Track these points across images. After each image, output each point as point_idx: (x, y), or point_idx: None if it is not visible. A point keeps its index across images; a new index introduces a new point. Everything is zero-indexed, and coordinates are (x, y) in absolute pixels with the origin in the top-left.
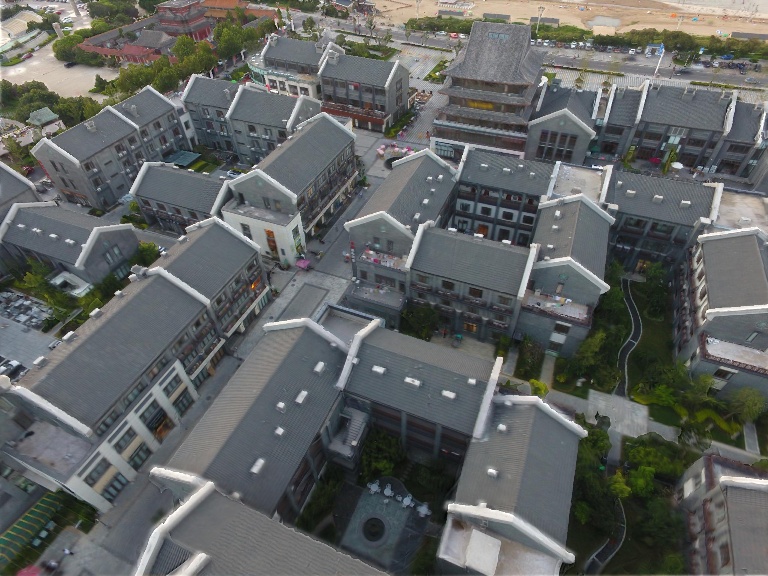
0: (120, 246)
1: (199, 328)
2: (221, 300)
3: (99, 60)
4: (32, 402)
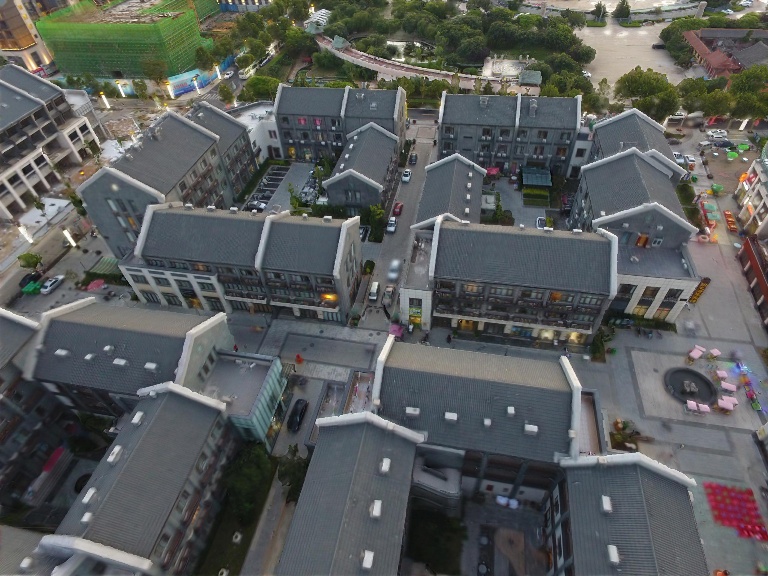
0: (362, 194)
1: (249, 276)
2: (280, 277)
3: (679, 53)
4: (144, 217)
